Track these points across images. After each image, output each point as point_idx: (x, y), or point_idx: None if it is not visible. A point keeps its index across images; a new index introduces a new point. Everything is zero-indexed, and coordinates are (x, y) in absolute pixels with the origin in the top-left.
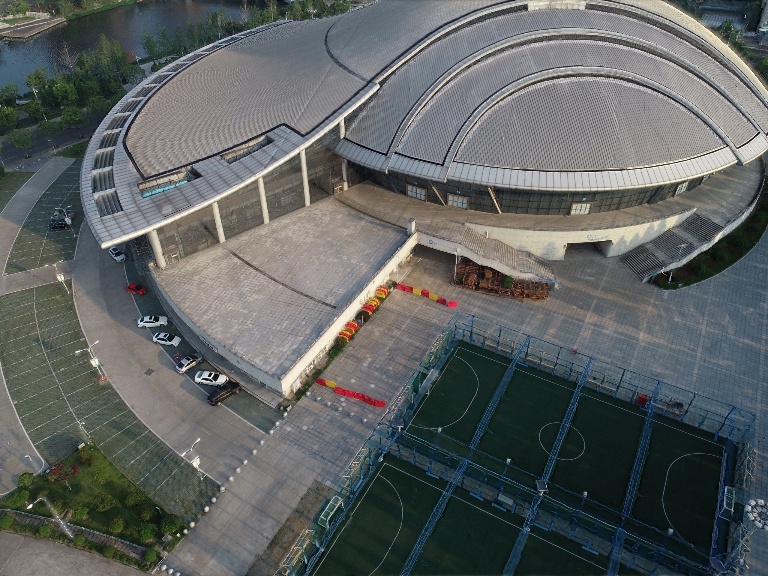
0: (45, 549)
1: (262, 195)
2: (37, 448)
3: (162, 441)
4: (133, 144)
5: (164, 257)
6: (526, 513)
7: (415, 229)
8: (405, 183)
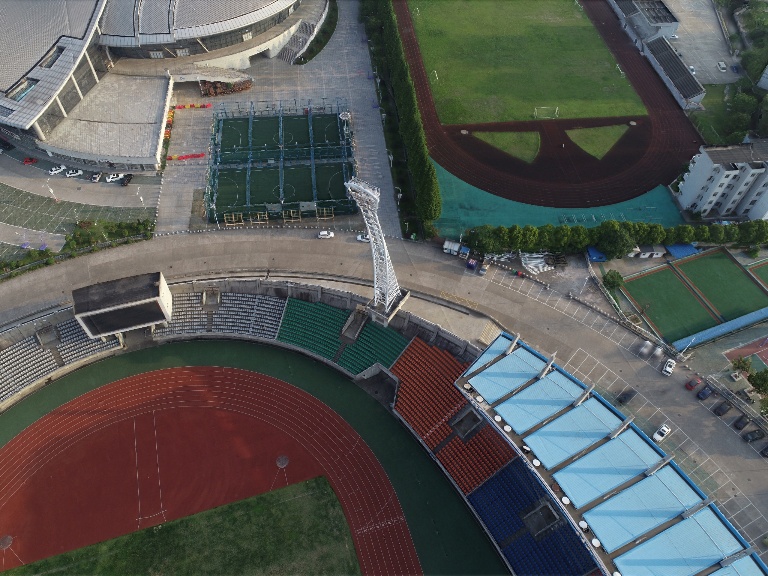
0: (100, 254)
1: (74, 82)
2: (55, 233)
3: (114, 207)
4: None
5: (43, 133)
6: None
7: (170, 74)
8: (148, 51)
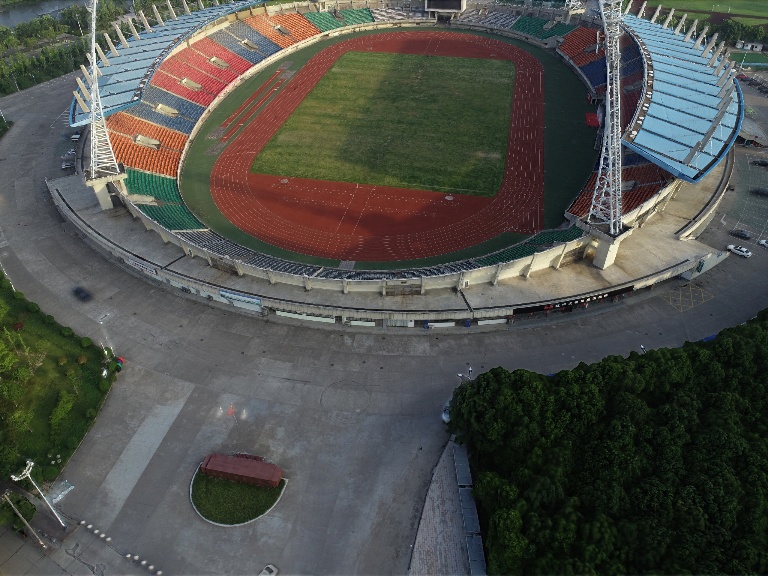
0: None
1: None
2: None
3: None
4: None
5: None
6: (539, 2)
7: None
8: None
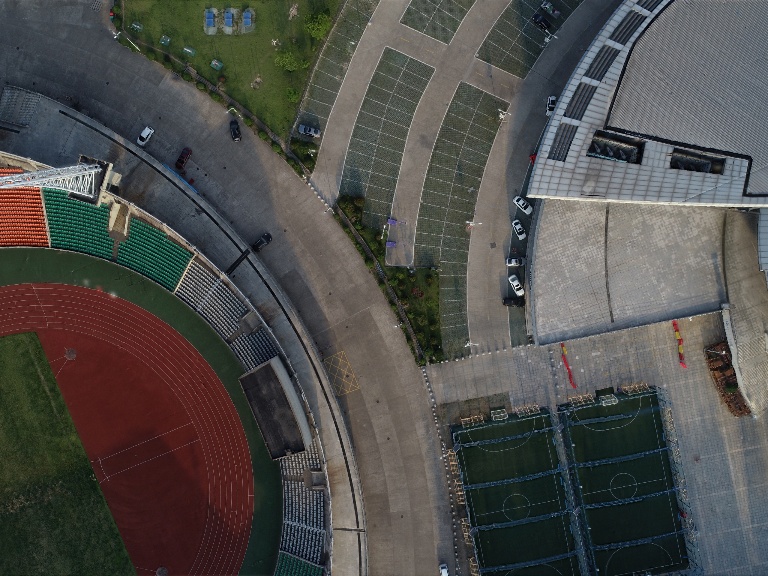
0: (389, 313)
1: None
2: (415, 248)
3: (467, 301)
4: (637, 56)
5: None
6: (568, 494)
7: None
8: None
